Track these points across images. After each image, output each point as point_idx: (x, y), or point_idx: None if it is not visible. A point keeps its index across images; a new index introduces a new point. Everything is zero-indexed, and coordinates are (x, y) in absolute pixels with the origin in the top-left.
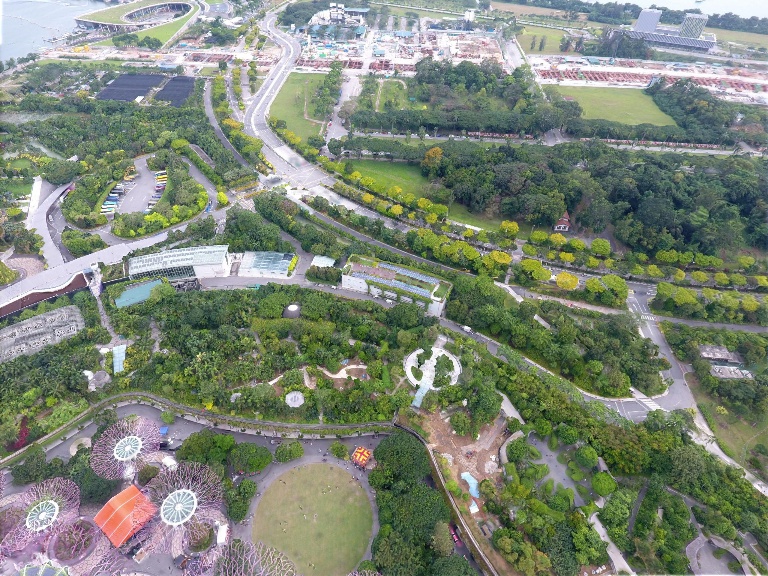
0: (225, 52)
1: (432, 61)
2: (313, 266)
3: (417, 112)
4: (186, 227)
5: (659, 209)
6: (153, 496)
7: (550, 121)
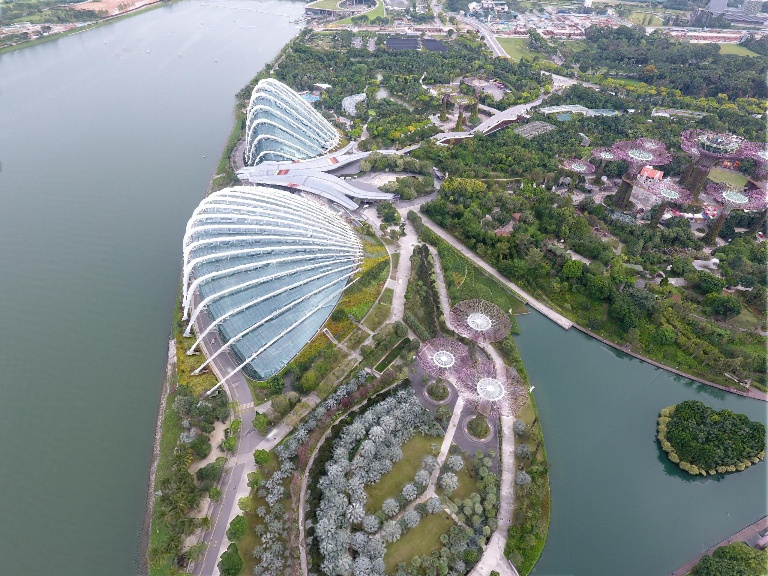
0: (434, 27)
1: (598, 27)
2: None
3: (617, 51)
4: None
5: None
6: None
7: (706, 53)
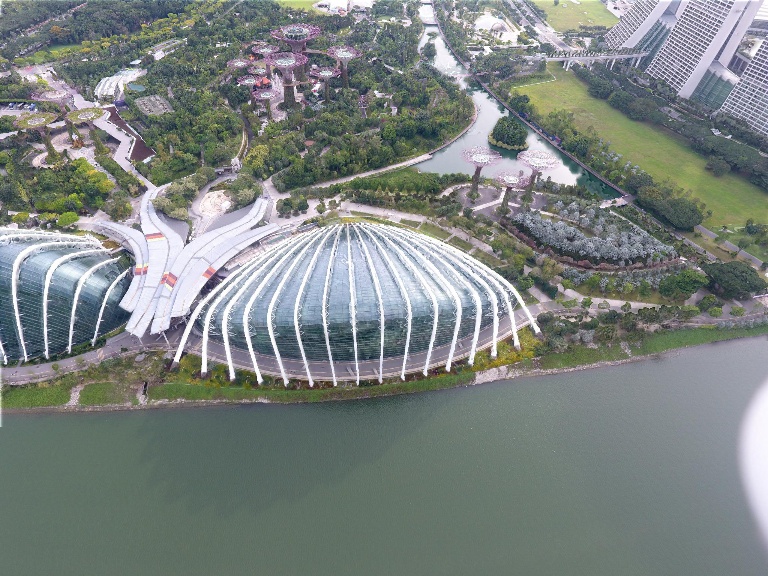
0: None
1: None
2: (143, 58)
3: None
4: None
5: None
6: None
7: (54, 3)
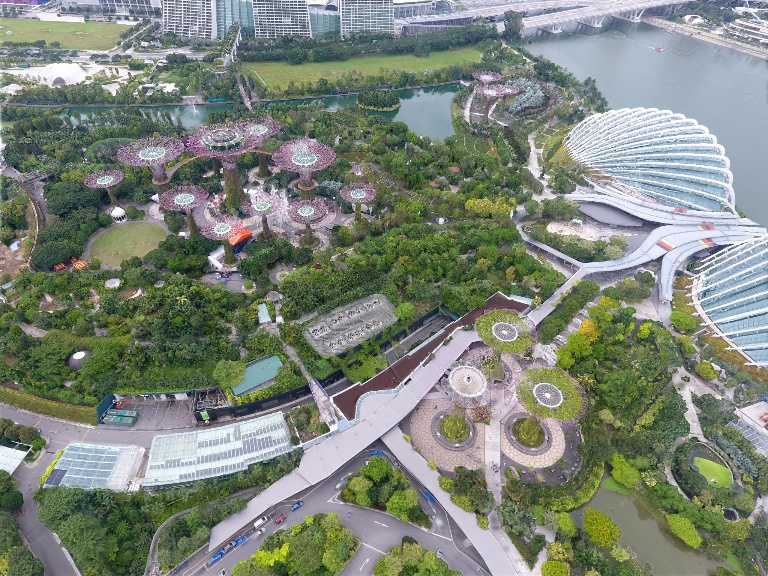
0: None
1: None
2: (23, 430)
3: None
4: None
5: None
6: None
7: None
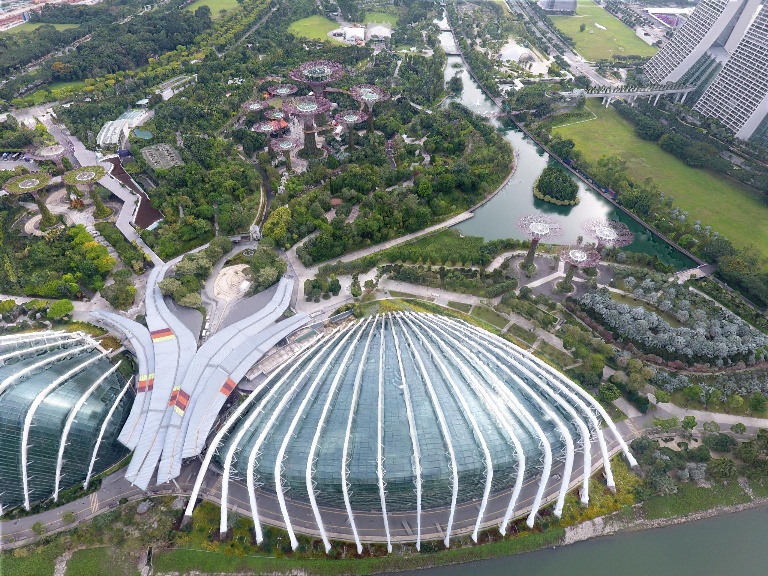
0: None
1: None
2: (151, 98)
3: None
4: None
5: (176, 24)
6: None
7: (58, 35)
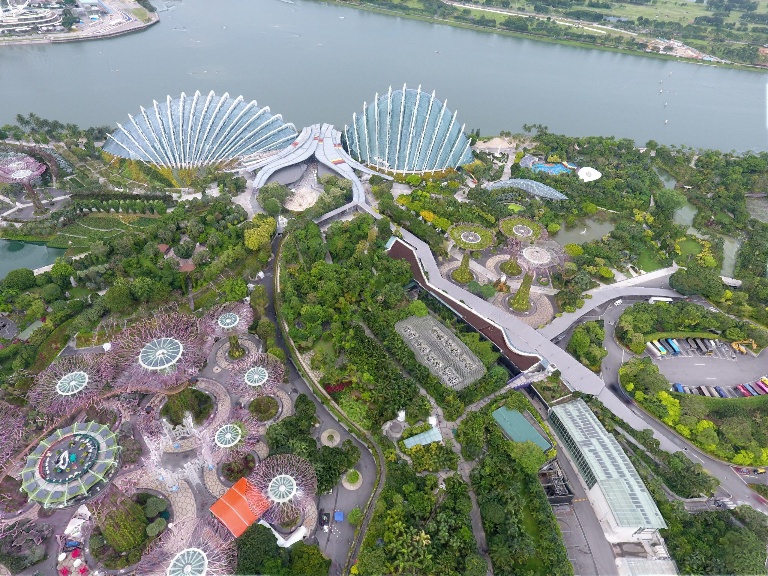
0: None
1: None
2: None
3: None
4: (675, 450)
5: None
6: (209, 535)
7: None
